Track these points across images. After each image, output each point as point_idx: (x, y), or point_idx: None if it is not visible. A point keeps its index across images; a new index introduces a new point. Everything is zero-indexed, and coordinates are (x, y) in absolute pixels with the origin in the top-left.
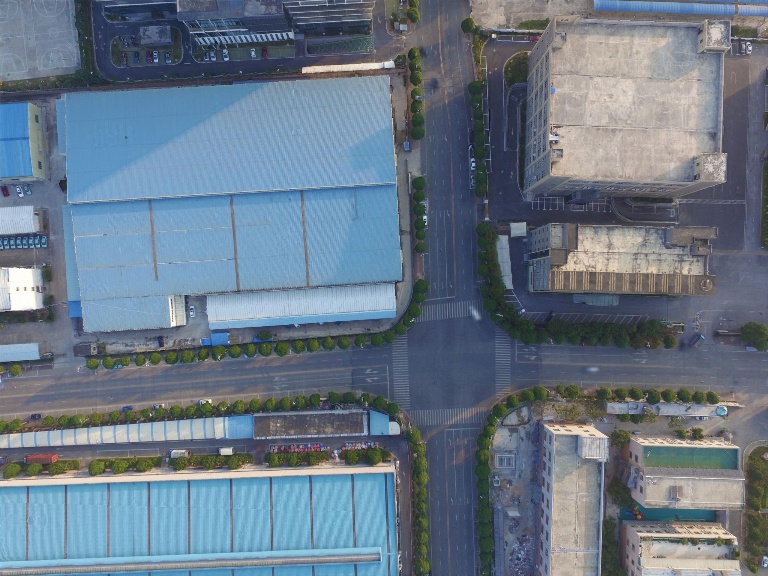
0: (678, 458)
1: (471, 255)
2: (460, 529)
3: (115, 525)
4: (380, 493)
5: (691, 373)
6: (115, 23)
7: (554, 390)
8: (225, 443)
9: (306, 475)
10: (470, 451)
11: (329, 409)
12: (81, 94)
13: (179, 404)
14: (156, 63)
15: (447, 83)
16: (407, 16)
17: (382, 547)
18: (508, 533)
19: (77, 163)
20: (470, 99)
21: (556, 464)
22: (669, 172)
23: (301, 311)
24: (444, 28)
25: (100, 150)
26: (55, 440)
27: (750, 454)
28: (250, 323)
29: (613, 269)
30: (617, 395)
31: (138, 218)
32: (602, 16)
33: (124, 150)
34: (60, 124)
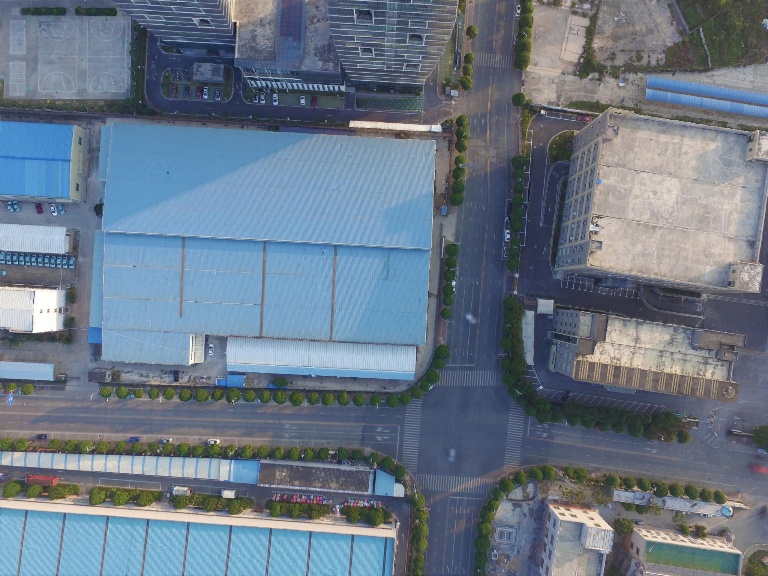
0: (680, 556)
1: (495, 325)
2: None
3: (109, 559)
4: (378, 557)
5: (700, 468)
6: (169, 55)
7: (563, 472)
8: (228, 485)
9: (307, 530)
10: (472, 521)
11: (336, 463)
12: (128, 124)
13: (187, 440)
14: (205, 99)
15: (491, 152)
16: (460, 83)
17: None
18: None
19: (116, 192)
20: (513, 172)
21: (558, 549)
22: (704, 275)
23: (320, 363)
24: (494, 98)
25: (140, 182)
26: (59, 463)
27: (750, 556)
28: (268, 369)
29: (638, 364)
30: (625, 484)
31: (170, 254)
32: (652, 105)
33: (164, 185)
34: (103, 150)
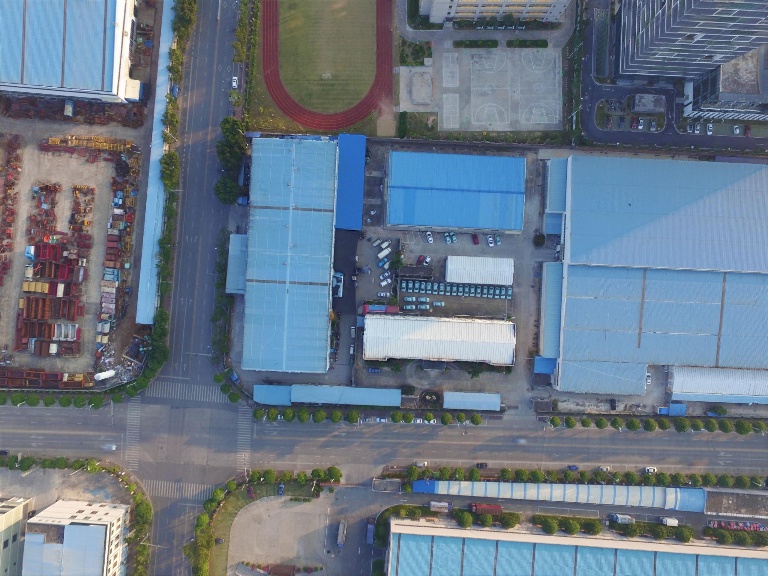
0: None
1: None
2: None
3: None
4: None
5: None
6: (603, 86)
7: None
8: (664, 512)
9: None
10: None
11: None
12: (587, 156)
13: (623, 469)
14: (639, 129)
15: None
16: None
17: None
18: None
19: (580, 225)
20: None
21: None
22: None
23: (765, 392)
24: None
25: (603, 214)
26: (505, 492)
27: None
28: (713, 398)
29: None
30: None
31: (631, 285)
32: None
33: (627, 217)
34: (553, 182)
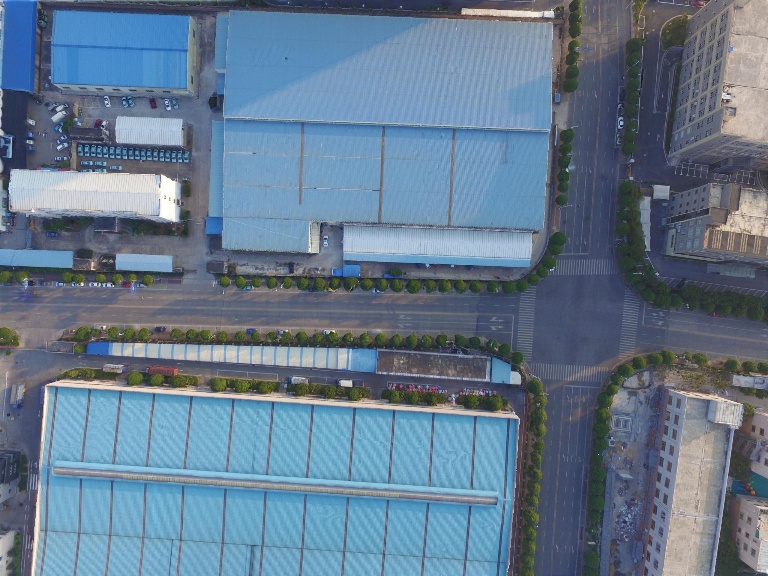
0: None
1: (609, 214)
2: (569, 486)
3: (236, 441)
4: (501, 438)
5: None
6: None
7: (684, 355)
8: (344, 375)
9: (430, 412)
10: (587, 410)
11: (451, 353)
12: (245, 11)
13: None
14: None
15: (603, 39)
16: None
17: (499, 492)
18: (617, 495)
19: (235, 79)
20: (628, 56)
21: (684, 427)
22: None
23: (436, 251)
24: None
25: (259, 68)
26: (179, 354)
27: None
28: (384, 258)
29: None
30: (745, 367)
31: (289, 140)
32: None
33: (283, 71)
34: (219, 40)
